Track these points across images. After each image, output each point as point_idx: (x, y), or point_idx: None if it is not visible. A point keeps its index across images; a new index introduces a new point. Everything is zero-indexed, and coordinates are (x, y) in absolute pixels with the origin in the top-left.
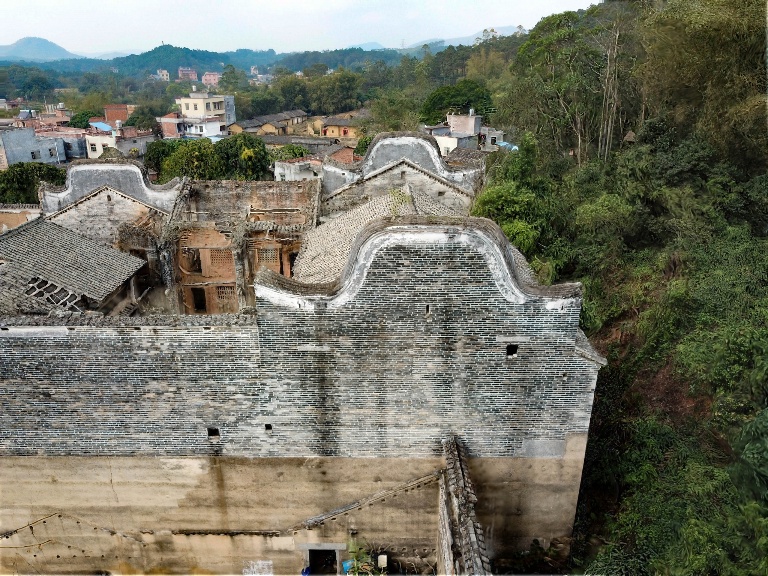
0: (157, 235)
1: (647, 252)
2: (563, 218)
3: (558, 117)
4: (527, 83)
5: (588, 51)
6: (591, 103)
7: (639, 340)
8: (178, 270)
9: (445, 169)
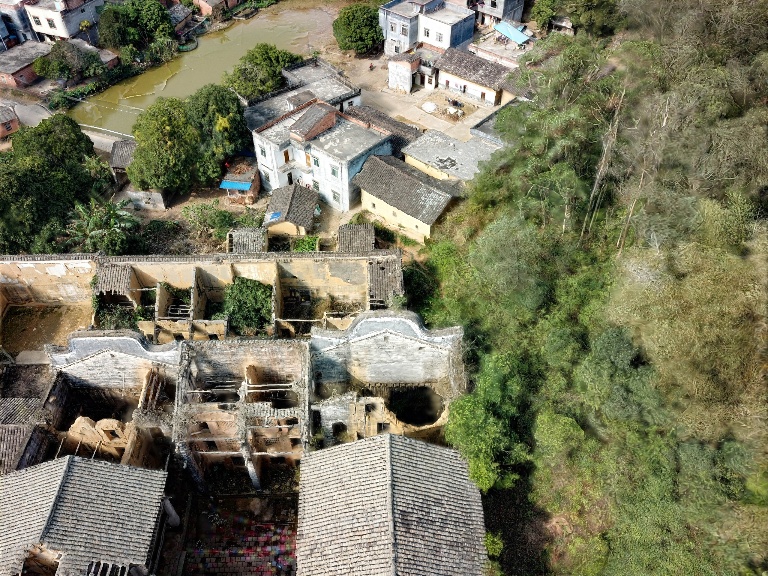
0: (162, 377)
1: (594, 446)
2: (528, 398)
3: (547, 186)
4: (511, 239)
5: (592, 86)
6: (586, 153)
7: (568, 561)
8: (190, 437)
9: (425, 335)
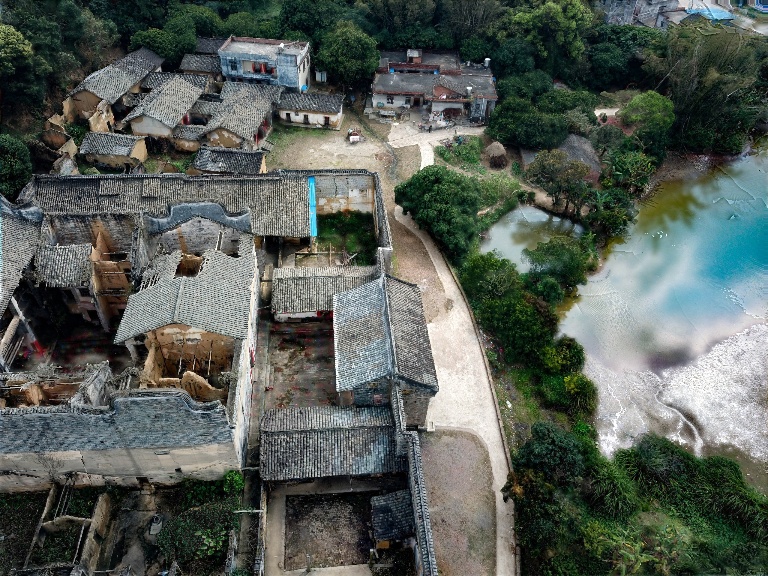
0: None
1: None
2: None
3: None
4: None
5: None
6: None
7: None
8: None
9: None
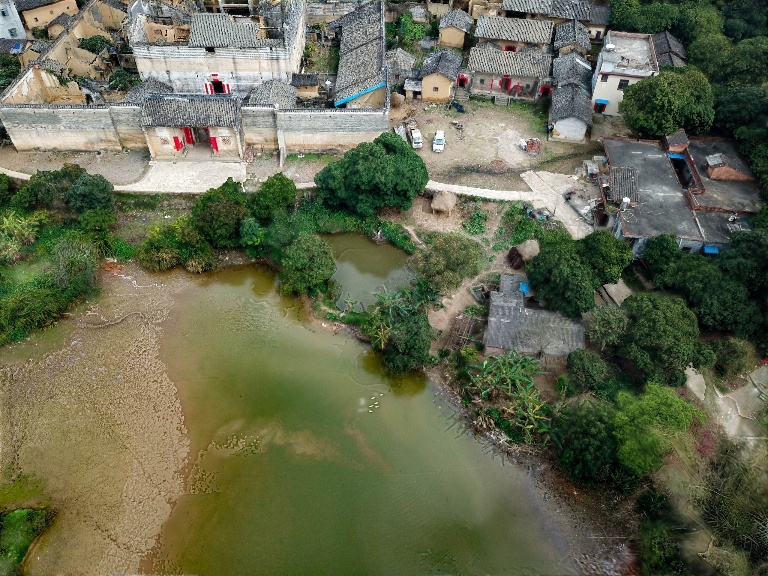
0: None
1: None
2: None
3: None
4: None
5: None
6: None
7: None
8: None
9: None
